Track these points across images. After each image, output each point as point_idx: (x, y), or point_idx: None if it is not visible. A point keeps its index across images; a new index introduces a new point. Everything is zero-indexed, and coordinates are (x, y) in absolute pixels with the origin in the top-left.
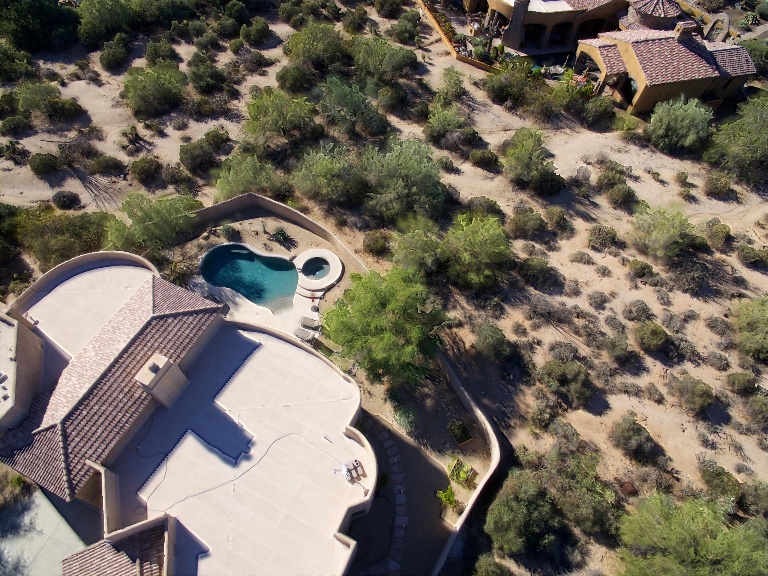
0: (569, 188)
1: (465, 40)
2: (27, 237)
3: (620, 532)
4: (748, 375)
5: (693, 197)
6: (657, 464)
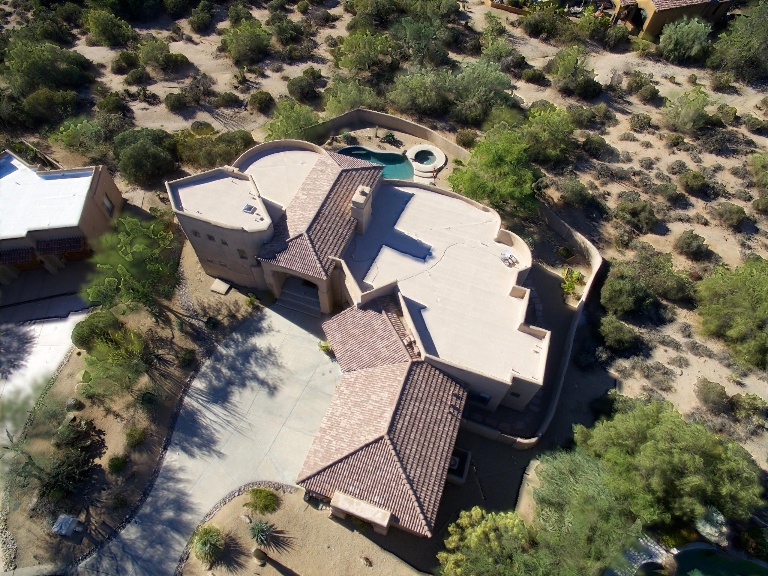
0: (606, 93)
1: None
2: (186, 152)
3: (697, 293)
4: (767, 198)
5: (703, 92)
6: (711, 261)
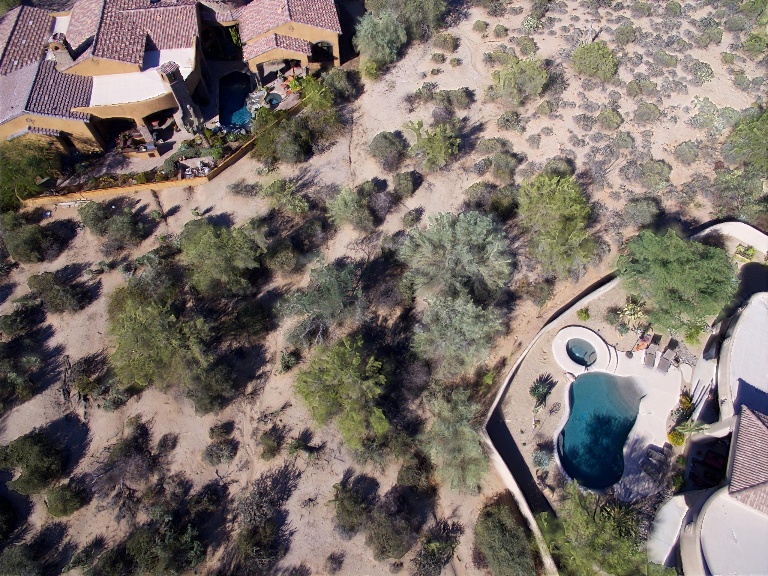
0: None
1: (178, 163)
2: None
3: None
4: (632, 83)
5: None
6: None
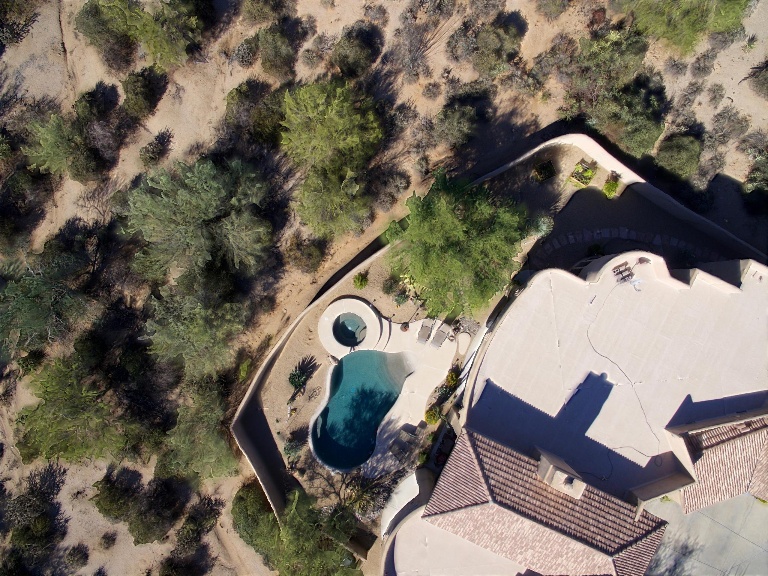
0: None
1: None
2: None
3: None
4: None
5: None
6: None
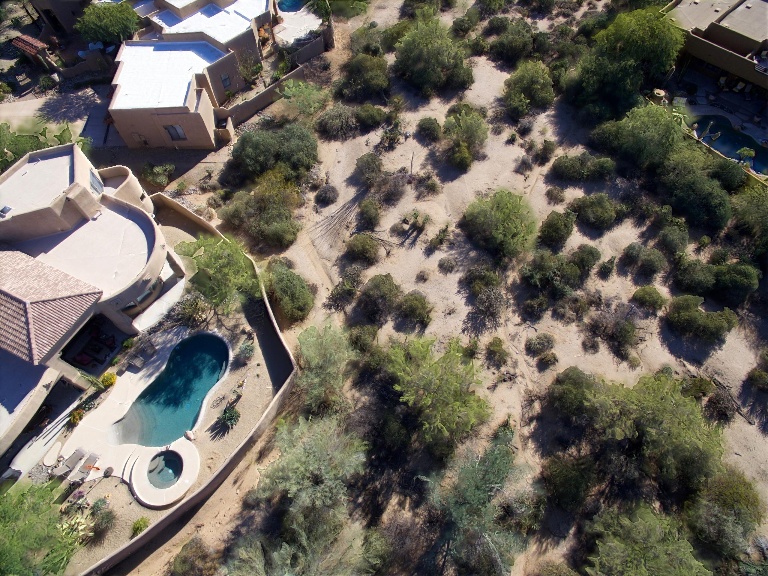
0: None
1: None
2: None
3: None
4: None
5: None
6: None
